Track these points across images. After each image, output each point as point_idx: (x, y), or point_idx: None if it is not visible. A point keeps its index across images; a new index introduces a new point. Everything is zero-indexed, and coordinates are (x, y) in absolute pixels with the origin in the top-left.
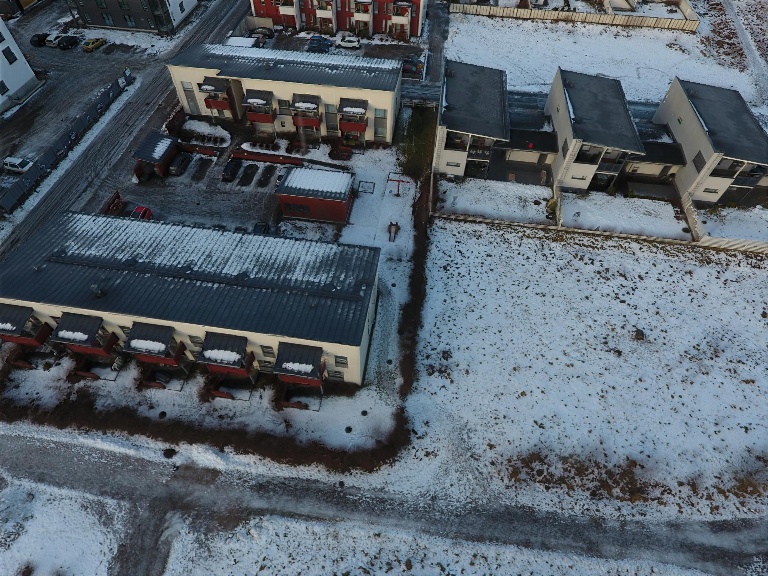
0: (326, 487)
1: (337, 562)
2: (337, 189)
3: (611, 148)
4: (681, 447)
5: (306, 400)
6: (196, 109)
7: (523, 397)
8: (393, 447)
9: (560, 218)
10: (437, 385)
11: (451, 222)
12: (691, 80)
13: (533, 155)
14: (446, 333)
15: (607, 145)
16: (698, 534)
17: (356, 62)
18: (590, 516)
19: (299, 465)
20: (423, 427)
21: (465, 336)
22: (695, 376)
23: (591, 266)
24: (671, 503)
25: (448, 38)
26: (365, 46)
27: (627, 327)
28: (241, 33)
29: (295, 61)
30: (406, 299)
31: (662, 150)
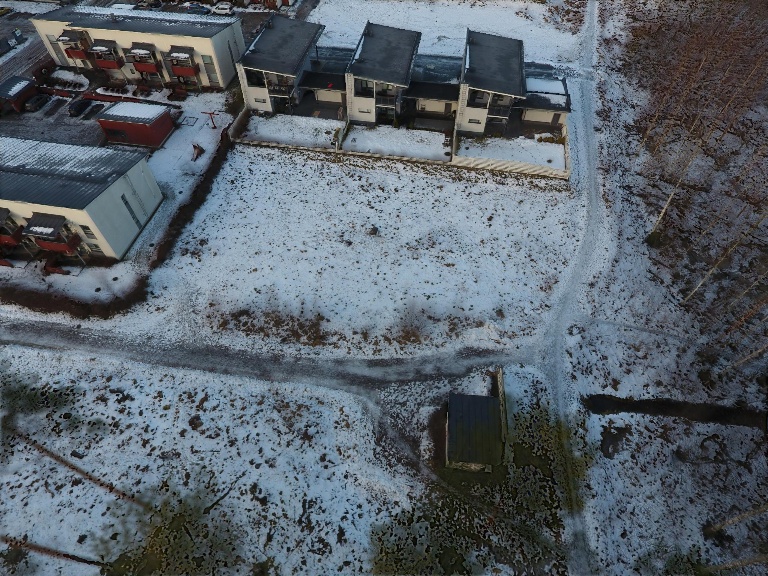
0: (66, 328)
1: (53, 375)
2: (147, 116)
3: (378, 81)
4: (367, 308)
5: (70, 268)
6: (65, 61)
7: (253, 272)
8: (128, 302)
9: (342, 144)
10: (186, 262)
11: (249, 147)
12: (523, 41)
13: (335, 95)
14: (210, 227)
15: (375, 79)
16: (355, 368)
17: (197, 18)
18: (273, 354)
19: (49, 313)
20: (161, 290)
21: (226, 230)
22: (405, 260)
23: (357, 181)
24: (344, 347)
25: (316, 7)
26: (239, 13)
27: (366, 225)
28: (130, 2)
29: (144, 17)
30: (186, 202)
31: (443, 89)
